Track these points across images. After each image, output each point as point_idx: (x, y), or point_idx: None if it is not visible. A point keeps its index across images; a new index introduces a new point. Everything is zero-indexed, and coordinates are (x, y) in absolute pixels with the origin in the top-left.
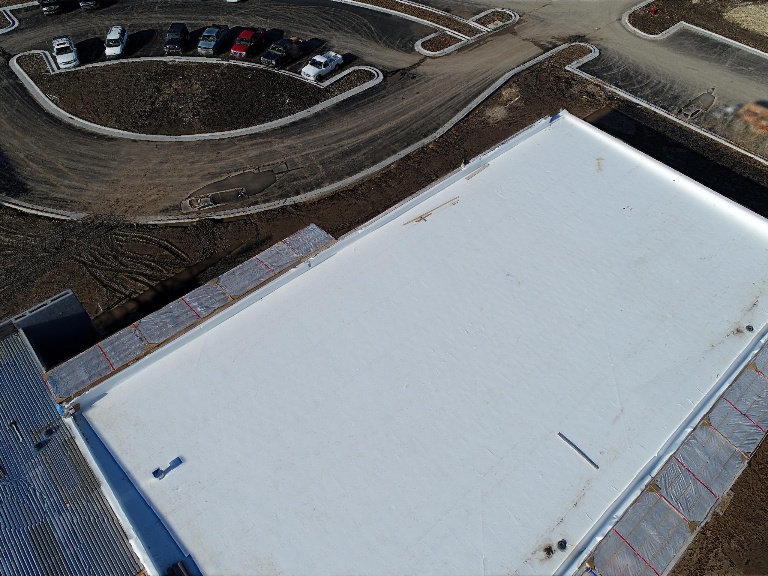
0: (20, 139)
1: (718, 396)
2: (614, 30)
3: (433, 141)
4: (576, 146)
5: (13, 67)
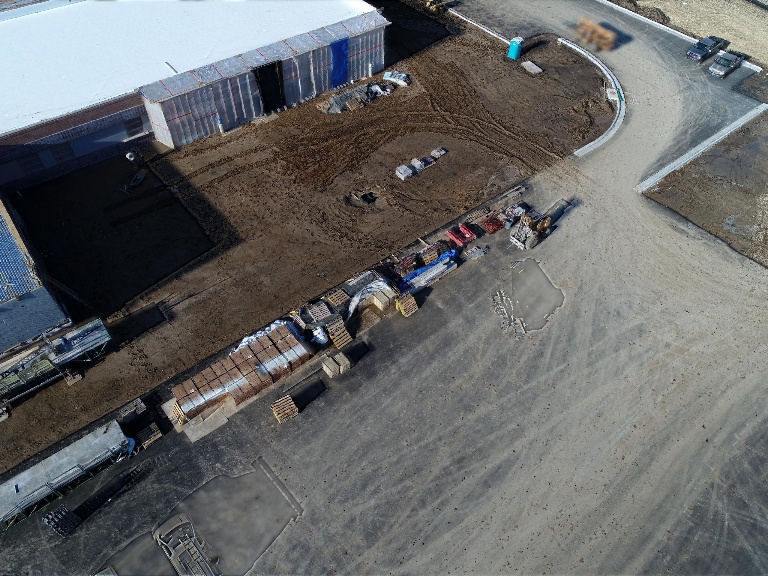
0: None
1: None
2: None
3: None
4: None
5: None
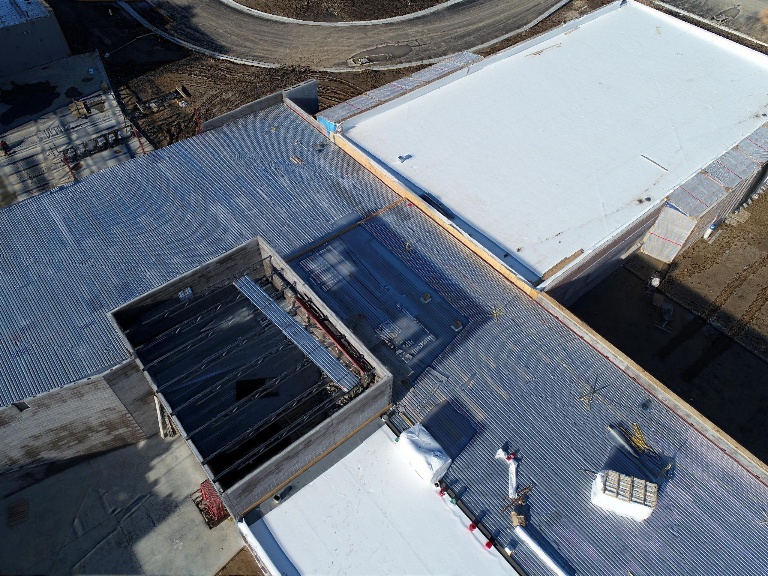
0: (216, 21)
1: (743, 139)
2: None
3: (525, 31)
4: (640, 20)
5: None
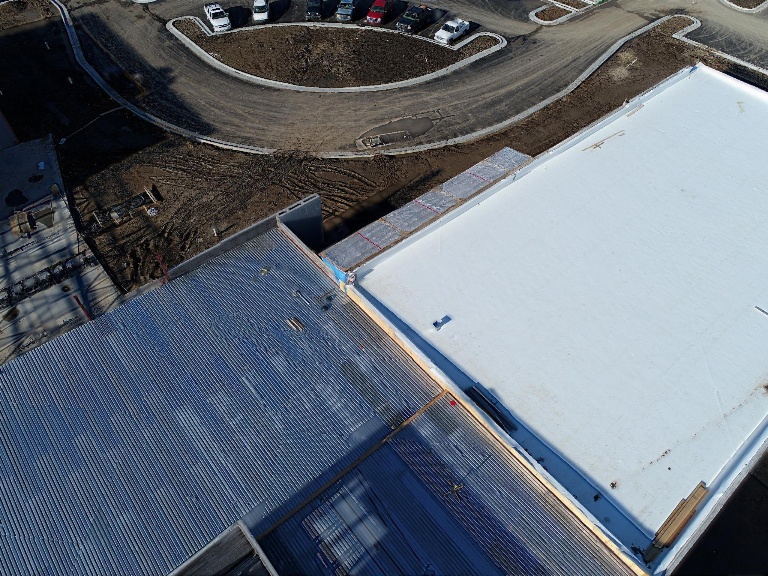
0: (197, 89)
1: None
2: (711, 4)
3: (566, 95)
4: (716, 92)
5: (171, 30)
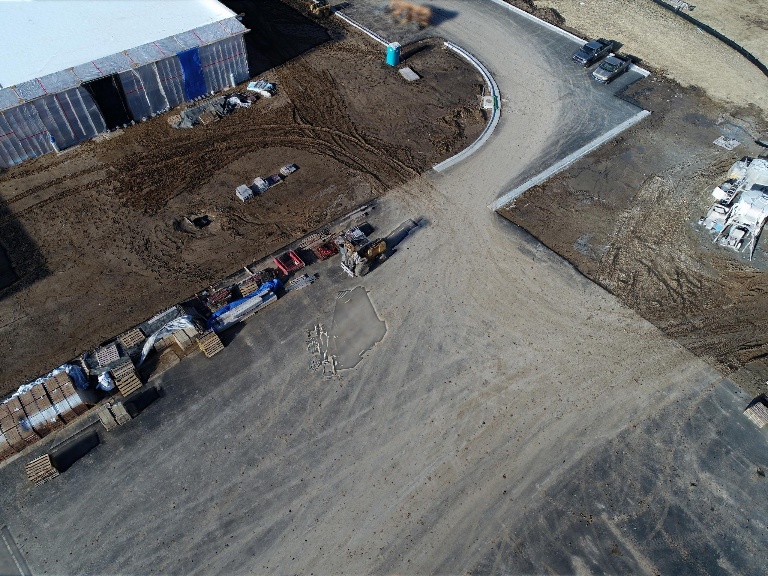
0: None
1: None
2: None
3: None
4: None
5: None
